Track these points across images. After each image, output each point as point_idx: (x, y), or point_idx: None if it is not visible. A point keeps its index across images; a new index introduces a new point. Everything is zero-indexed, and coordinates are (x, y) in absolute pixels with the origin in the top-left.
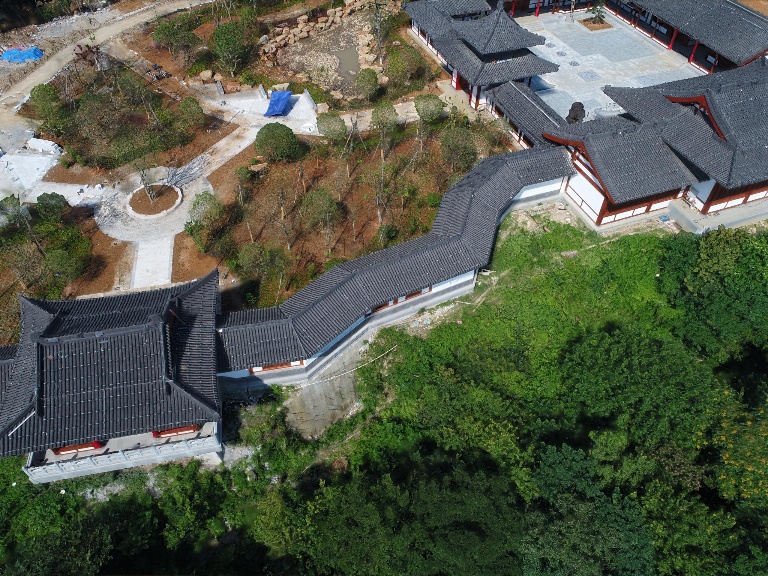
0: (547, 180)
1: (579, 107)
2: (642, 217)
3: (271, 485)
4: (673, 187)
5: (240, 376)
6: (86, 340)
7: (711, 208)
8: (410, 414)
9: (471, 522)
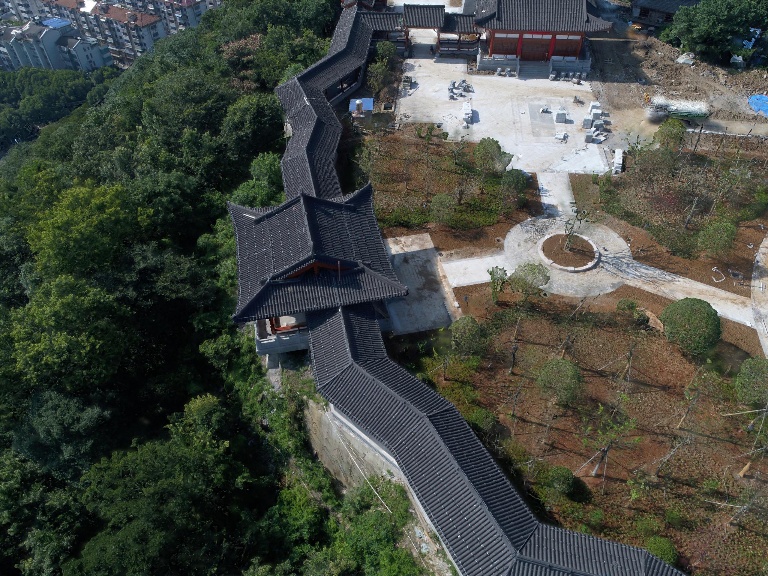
0: None
1: None
2: None
3: (260, 419)
4: None
5: None
6: None
7: None
8: None
9: (128, 571)
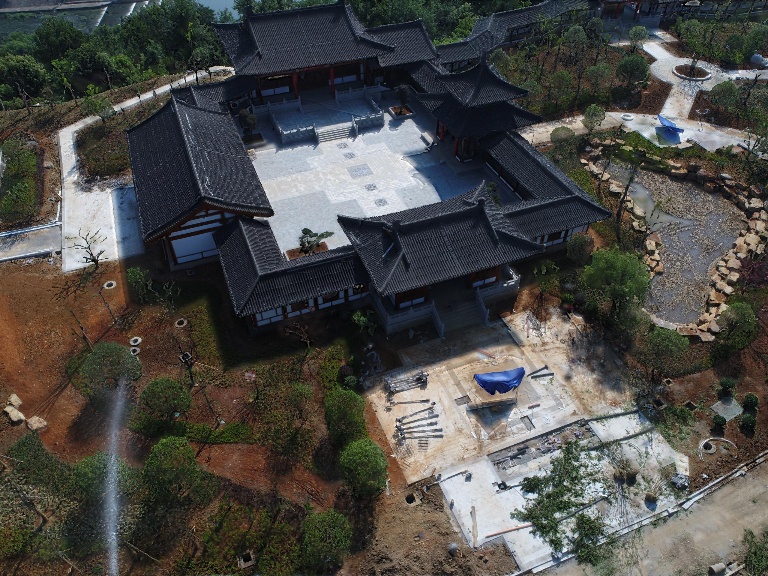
0: None
1: None
2: None
3: None
4: None
5: None
6: None
7: None
8: None
9: None
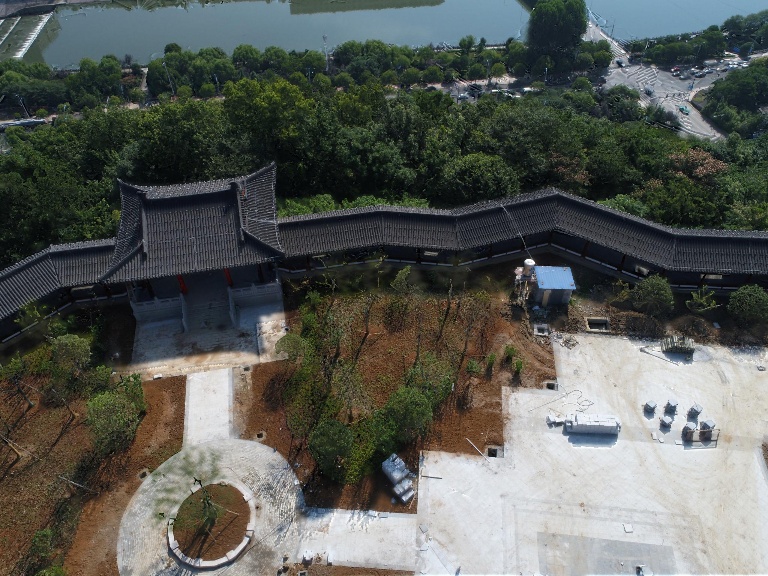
0: None
1: None
2: None
3: None
4: None
5: None
6: None
7: None
8: None
9: None
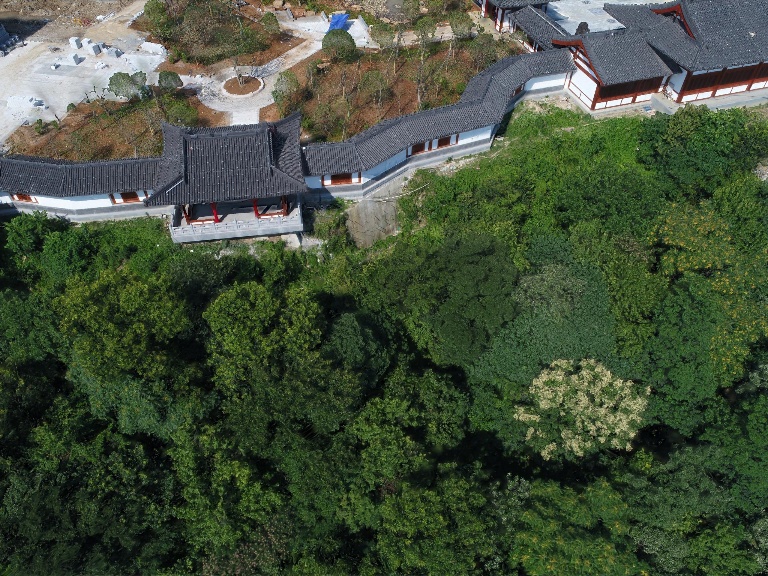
0: (553, 73)
1: (584, 26)
2: (629, 106)
3: None
4: (652, 76)
5: (315, 187)
6: (215, 139)
7: (684, 98)
8: (437, 236)
9: None
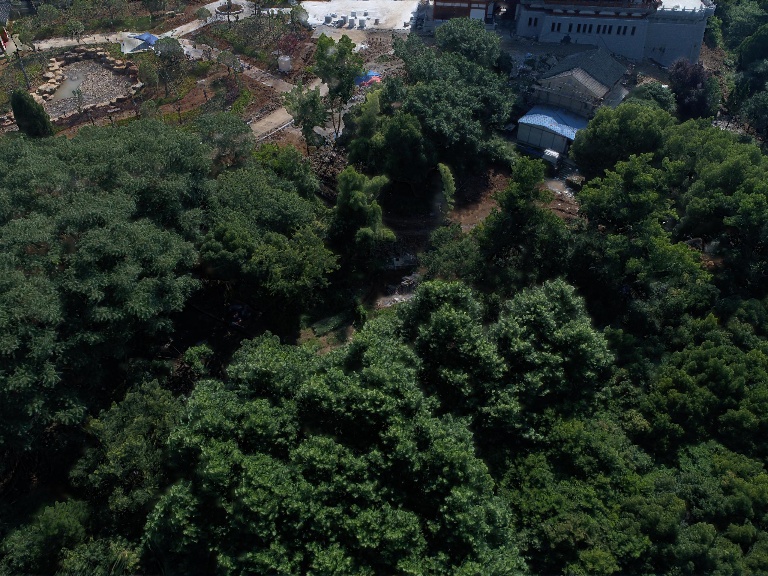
0: None
1: None
2: None
3: None
4: None
5: None
6: None
7: None
8: None
9: None
